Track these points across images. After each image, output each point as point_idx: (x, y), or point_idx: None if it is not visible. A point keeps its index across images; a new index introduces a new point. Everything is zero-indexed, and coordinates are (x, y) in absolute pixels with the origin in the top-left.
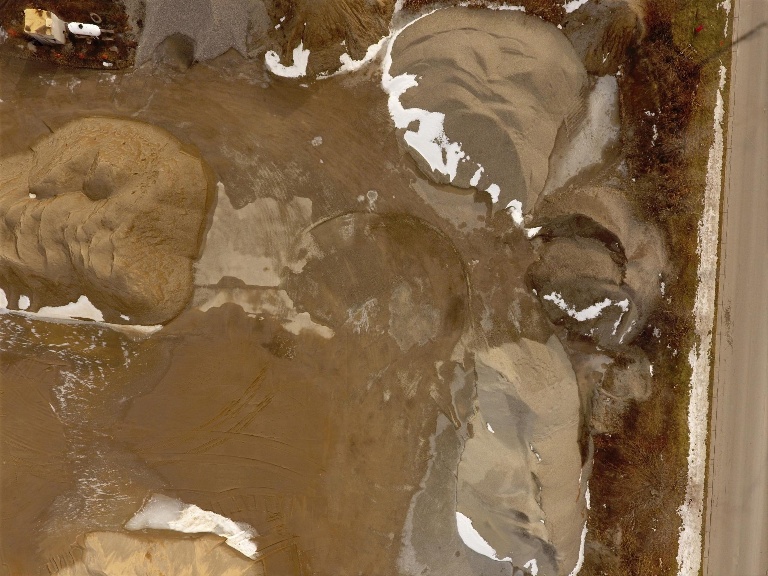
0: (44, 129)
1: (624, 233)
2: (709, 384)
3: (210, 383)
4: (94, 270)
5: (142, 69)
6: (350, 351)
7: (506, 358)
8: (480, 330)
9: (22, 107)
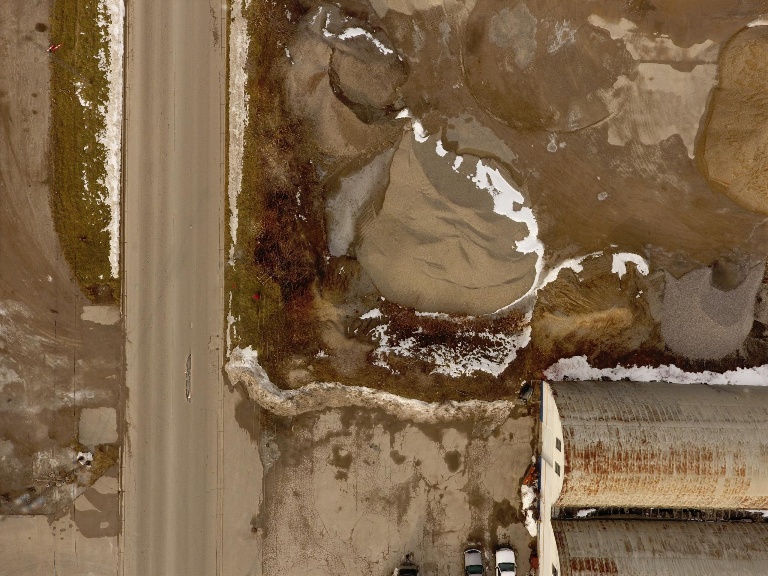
0: None
1: (327, 103)
2: None
3: None
4: None
5: (759, 260)
6: (573, 3)
7: None
8: (451, 22)
9: None
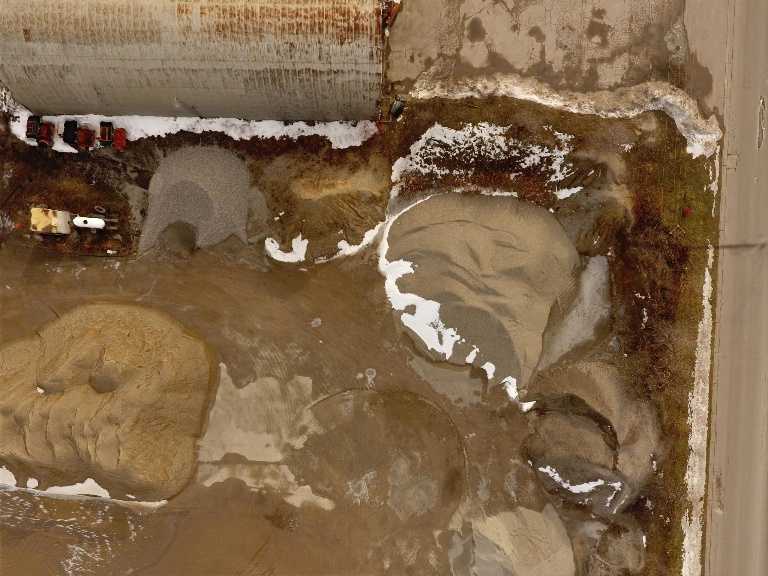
0: (50, 314)
1: (616, 415)
2: (701, 548)
3: (214, 555)
4: (101, 465)
5: (145, 256)
6: (350, 522)
7: (503, 528)
8: (477, 500)
9: (29, 293)
